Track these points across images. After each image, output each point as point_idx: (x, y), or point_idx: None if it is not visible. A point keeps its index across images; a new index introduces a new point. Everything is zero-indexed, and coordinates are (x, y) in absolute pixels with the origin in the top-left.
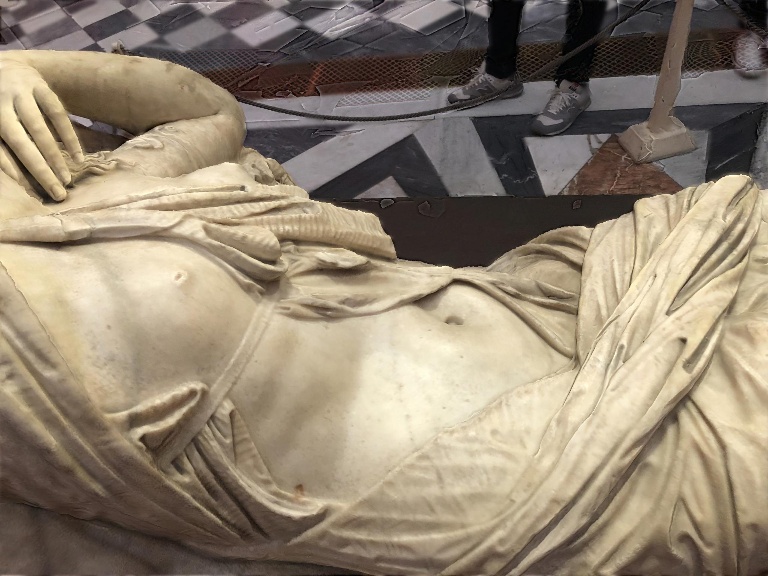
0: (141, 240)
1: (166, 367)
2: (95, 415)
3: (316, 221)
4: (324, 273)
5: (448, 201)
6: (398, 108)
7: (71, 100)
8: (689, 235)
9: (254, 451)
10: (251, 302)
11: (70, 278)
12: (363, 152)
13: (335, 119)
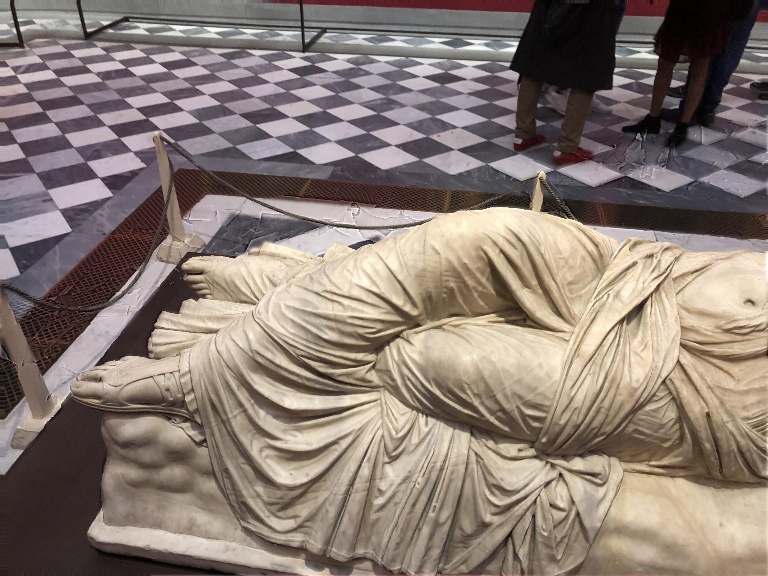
0: None
1: None
2: None
3: None
4: None
5: None
6: None
7: None
8: (627, 295)
9: None
10: None
11: None
12: None
13: None
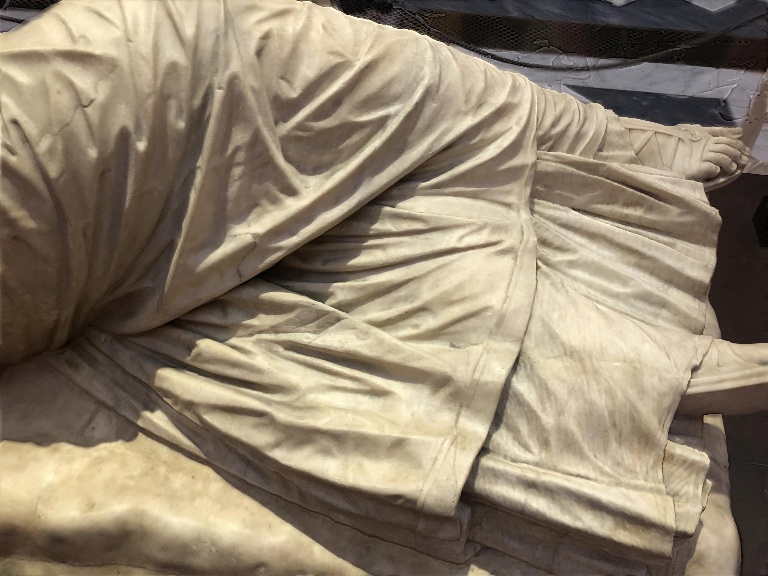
0: None
1: None
2: None
3: None
4: None
5: None
6: None
7: None
8: None
9: None
10: None
11: None
12: None
13: (9, 20)
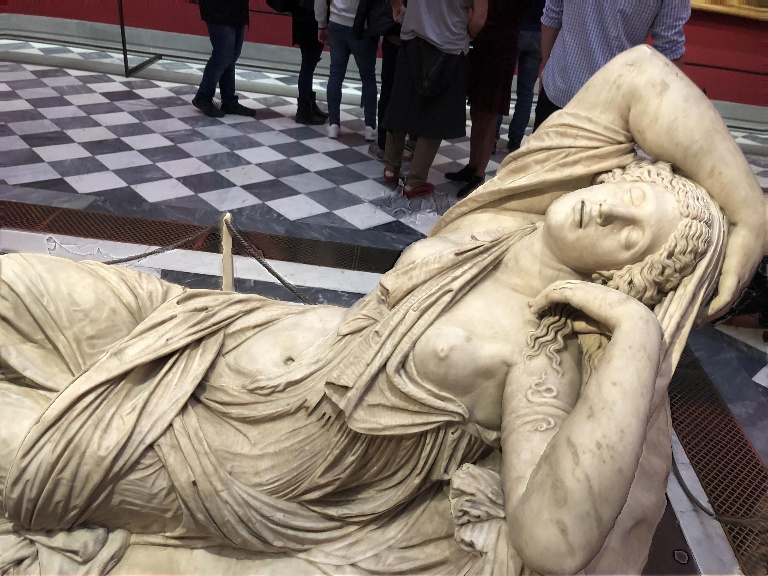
0: None
1: None
2: None
3: None
4: None
5: None
6: None
7: None
8: (133, 353)
9: None
10: None
11: (460, 235)
12: None
13: None
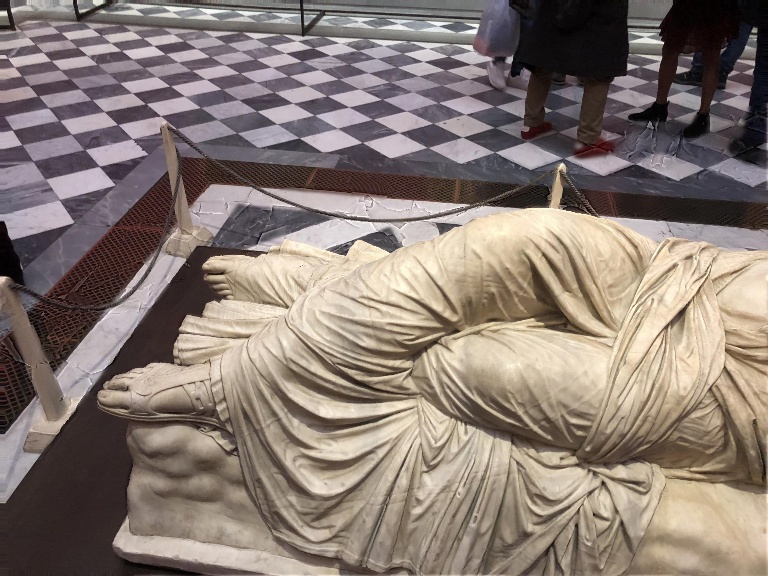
0: None
1: None
2: None
3: None
4: None
5: None
6: None
7: None
8: (671, 300)
9: None
10: None
11: None
12: None
13: None
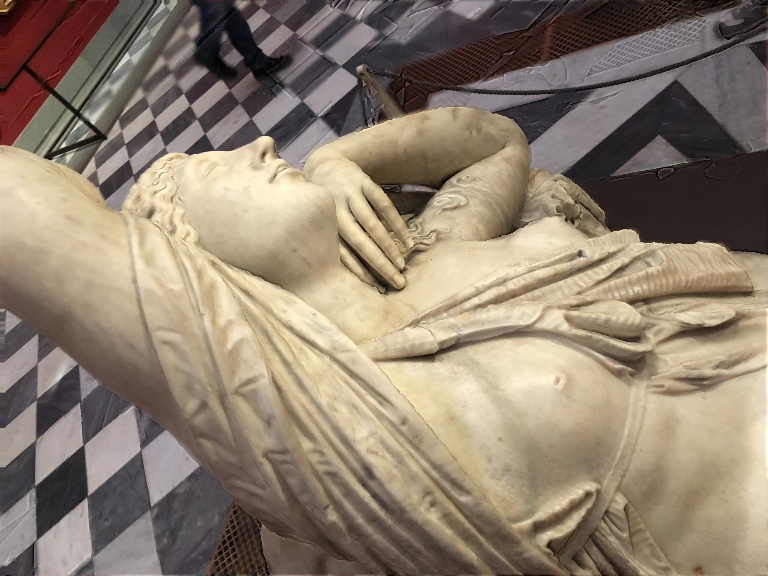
0: (505, 338)
1: (559, 471)
2: (508, 531)
3: (664, 273)
4: (688, 335)
5: (744, 159)
6: (661, 60)
7: (379, 175)
8: None
9: (650, 540)
10: (624, 387)
11: (454, 391)
12: (620, 113)
13: (588, 89)
